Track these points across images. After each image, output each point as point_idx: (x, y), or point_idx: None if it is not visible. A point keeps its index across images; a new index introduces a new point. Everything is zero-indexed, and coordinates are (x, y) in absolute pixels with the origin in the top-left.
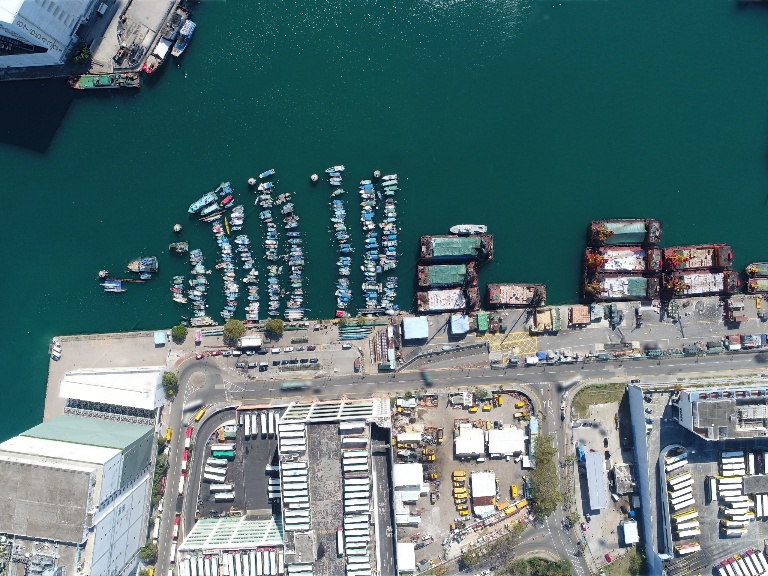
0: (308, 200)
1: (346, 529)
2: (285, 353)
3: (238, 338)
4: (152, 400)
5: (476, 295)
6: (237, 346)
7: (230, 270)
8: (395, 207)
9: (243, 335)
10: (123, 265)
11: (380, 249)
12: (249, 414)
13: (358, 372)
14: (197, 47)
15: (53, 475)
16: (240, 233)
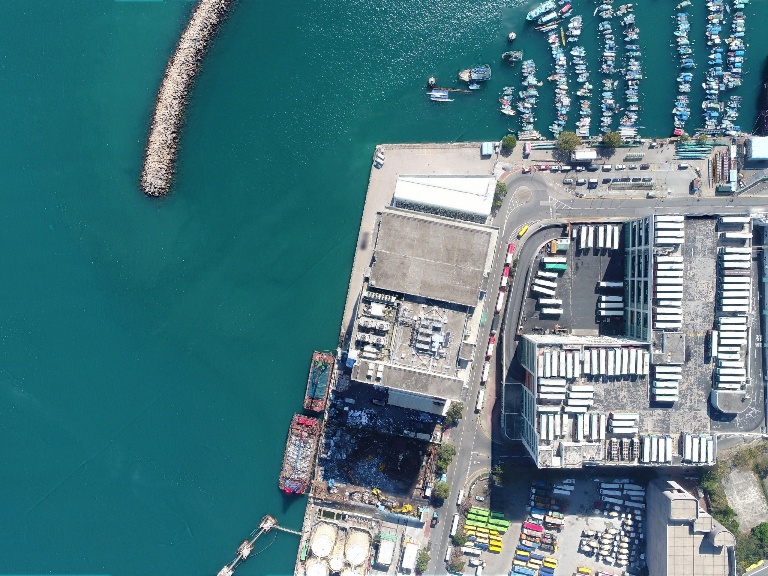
0: (650, 12)
1: (721, 330)
2: (616, 171)
3: (573, 150)
4: (489, 204)
5: None
6: (566, 161)
7: (563, 83)
8: (744, 22)
9: (575, 149)
10: (451, 74)
11: (724, 66)
12: (586, 226)
13: (693, 194)
14: None
15: (452, 233)
16: (576, 45)
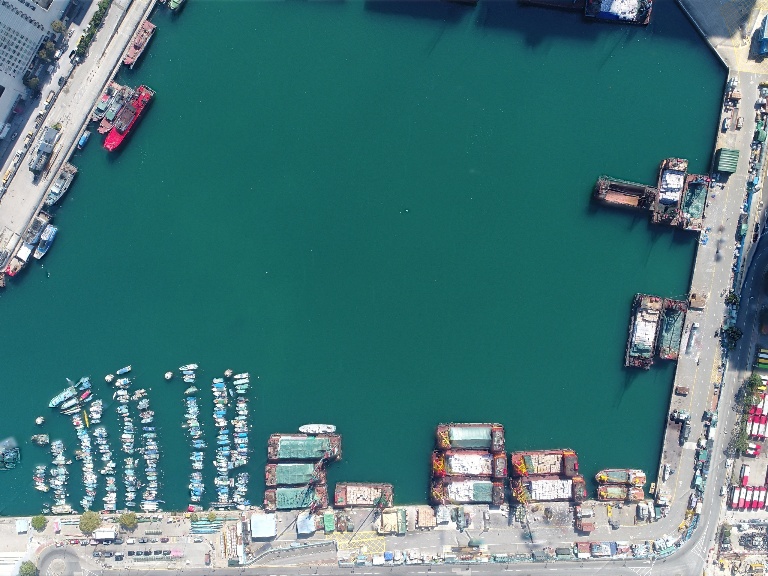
0: (163, 396)
1: None
2: (140, 544)
3: (92, 531)
4: None
5: (322, 496)
6: None
7: (89, 461)
8: (246, 405)
9: (99, 526)
10: None
11: (232, 445)
12: None
13: (209, 565)
14: (60, 248)
15: None
16: (99, 426)
